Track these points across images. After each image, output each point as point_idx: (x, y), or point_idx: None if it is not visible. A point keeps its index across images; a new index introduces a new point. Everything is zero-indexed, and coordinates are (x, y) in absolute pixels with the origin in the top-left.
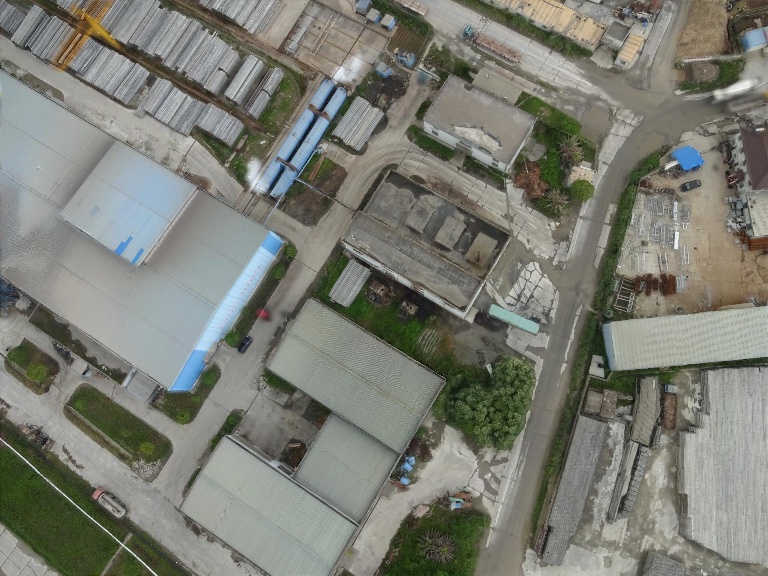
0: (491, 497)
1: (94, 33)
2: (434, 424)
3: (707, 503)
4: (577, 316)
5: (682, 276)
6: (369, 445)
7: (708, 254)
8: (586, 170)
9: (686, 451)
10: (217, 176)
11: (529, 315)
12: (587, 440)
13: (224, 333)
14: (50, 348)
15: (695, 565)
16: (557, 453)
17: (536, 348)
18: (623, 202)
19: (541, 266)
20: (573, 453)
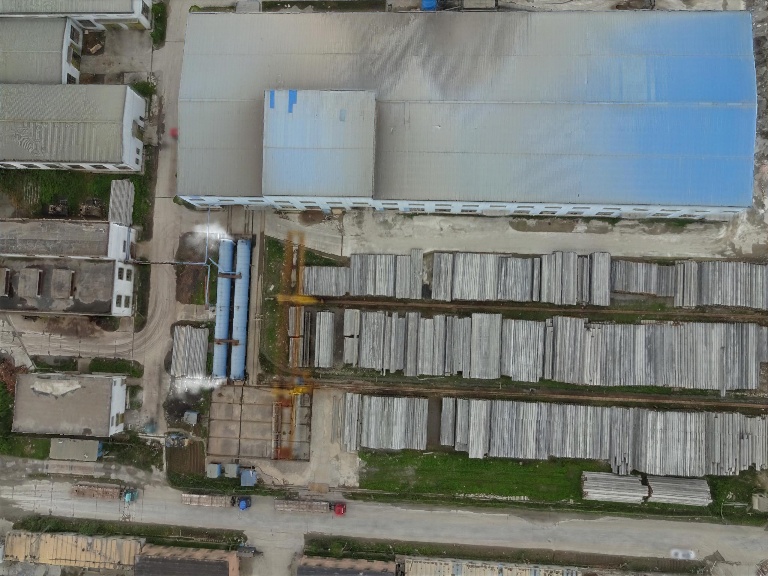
0: None
1: (525, 311)
2: None
3: None
4: None
5: None
6: None
7: None
8: None
9: None
10: (299, 233)
11: None
12: None
13: None
14: None
15: None
16: None
17: None
18: None
19: None
20: None
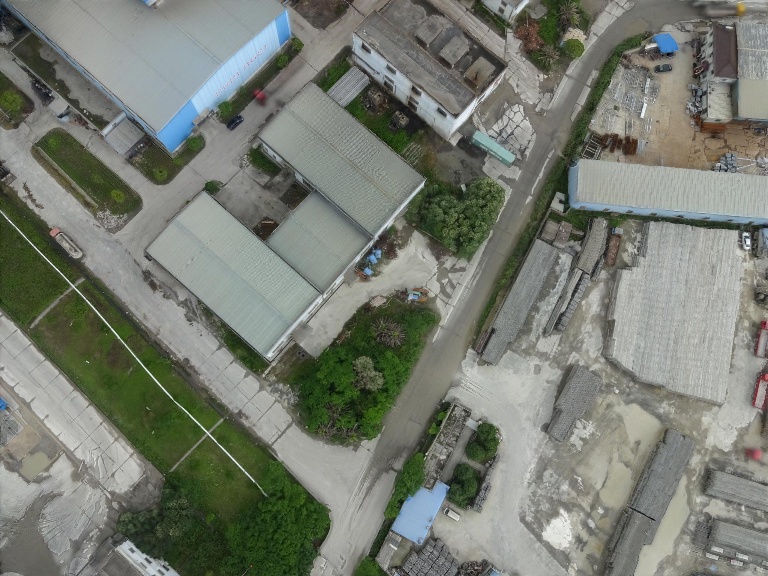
0: (445, 299)
1: None
2: (404, 227)
3: (630, 329)
4: (548, 158)
5: (643, 140)
6: (341, 233)
7: (667, 127)
8: (580, 33)
9: (621, 284)
10: None
11: (507, 149)
12: (539, 260)
13: (218, 103)
14: (27, 87)
15: (610, 382)
16: (511, 268)
17: (508, 178)
18: (605, 69)
19: (525, 109)
20: (525, 269)
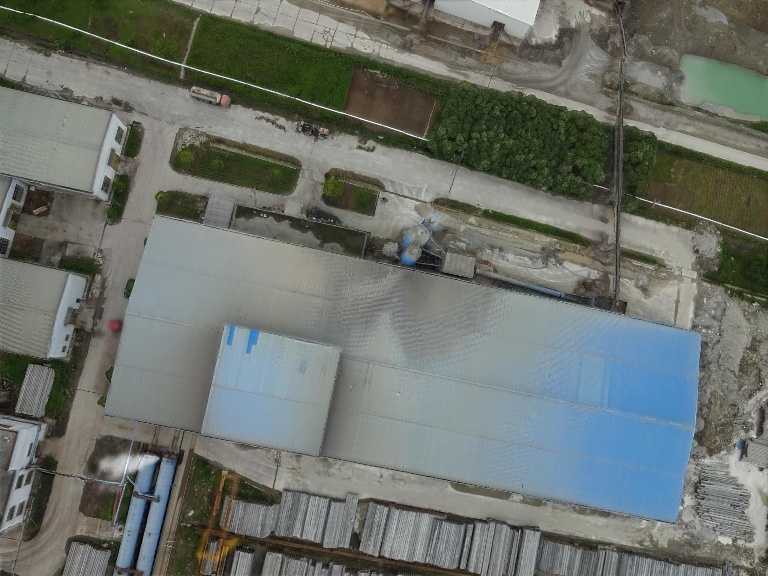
0: None
1: (450, 575)
2: None
3: None
4: None
5: None
6: None
7: None
8: None
9: None
10: (231, 456)
11: None
12: None
13: None
14: (342, 216)
15: None
16: None
17: None
18: None
19: None
20: None
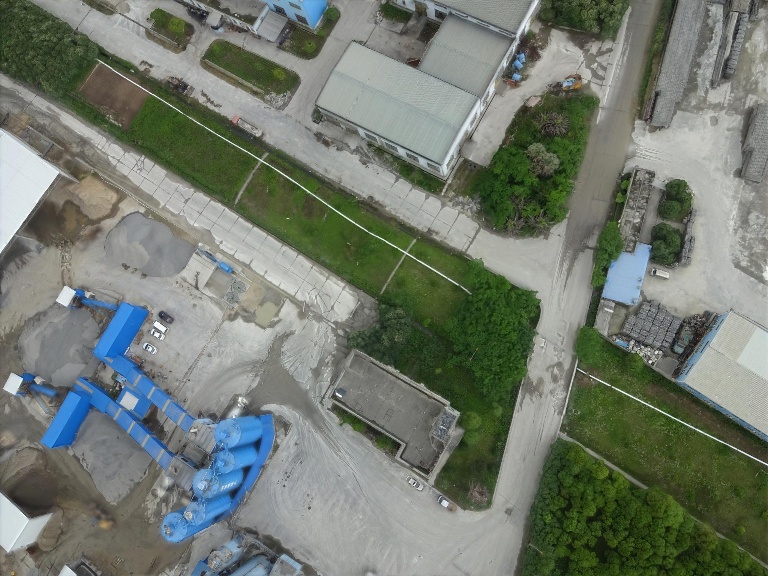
0: (598, 82)
1: None
2: (541, 30)
3: None
4: None
5: None
6: (482, 49)
7: None
8: None
9: None
10: None
11: None
12: (688, 15)
13: None
14: (185, 15)
15: None
16: (660, 32)
17: None
18: None
19: None
20: (676, 27)
